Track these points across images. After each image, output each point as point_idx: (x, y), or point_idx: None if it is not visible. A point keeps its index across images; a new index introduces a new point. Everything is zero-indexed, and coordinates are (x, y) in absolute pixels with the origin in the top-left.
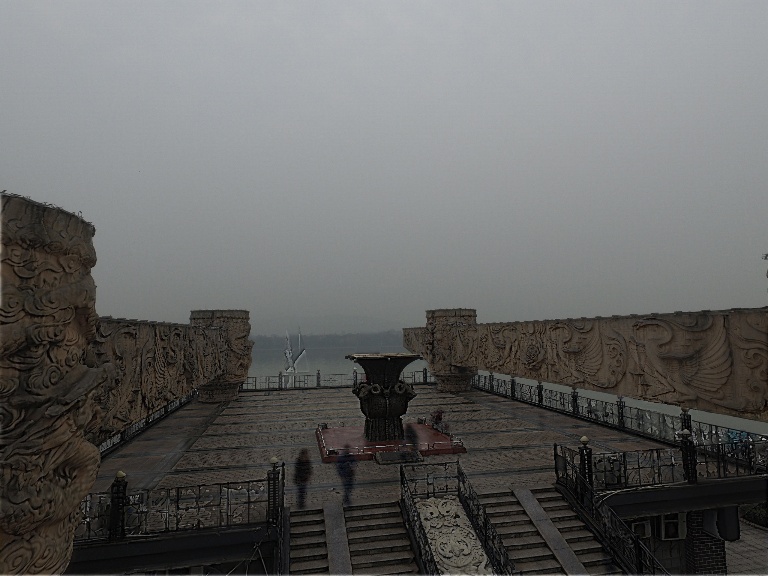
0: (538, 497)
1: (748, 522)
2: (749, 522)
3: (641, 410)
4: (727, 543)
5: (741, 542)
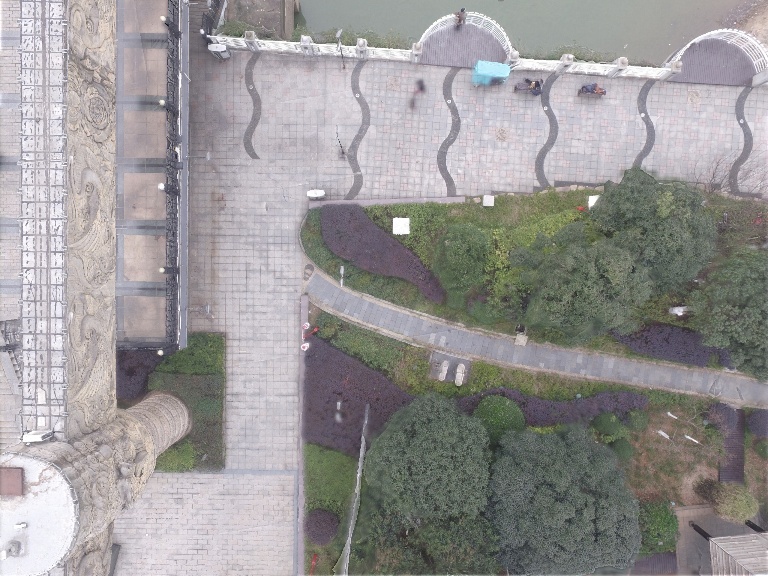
0: (3, 329)
1: (299, 237)
2: (300, 237)
3: (166, 218)
4: (254, 258)
5: (265, 259)
